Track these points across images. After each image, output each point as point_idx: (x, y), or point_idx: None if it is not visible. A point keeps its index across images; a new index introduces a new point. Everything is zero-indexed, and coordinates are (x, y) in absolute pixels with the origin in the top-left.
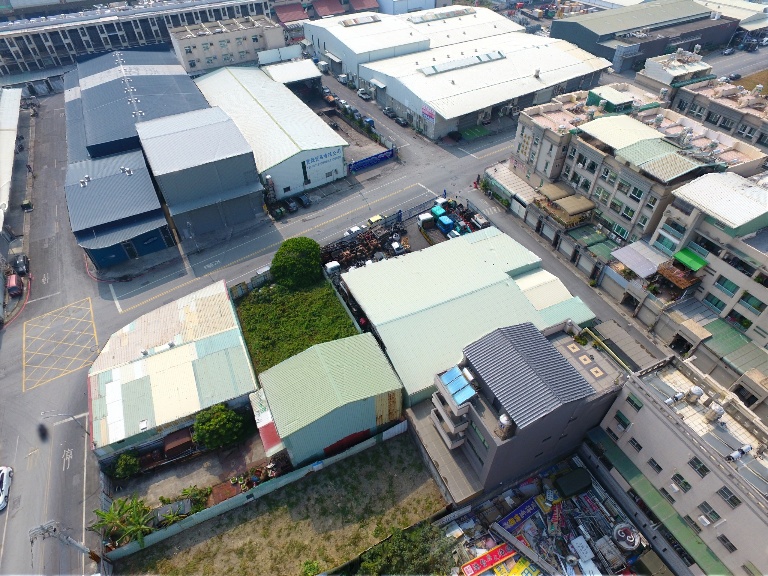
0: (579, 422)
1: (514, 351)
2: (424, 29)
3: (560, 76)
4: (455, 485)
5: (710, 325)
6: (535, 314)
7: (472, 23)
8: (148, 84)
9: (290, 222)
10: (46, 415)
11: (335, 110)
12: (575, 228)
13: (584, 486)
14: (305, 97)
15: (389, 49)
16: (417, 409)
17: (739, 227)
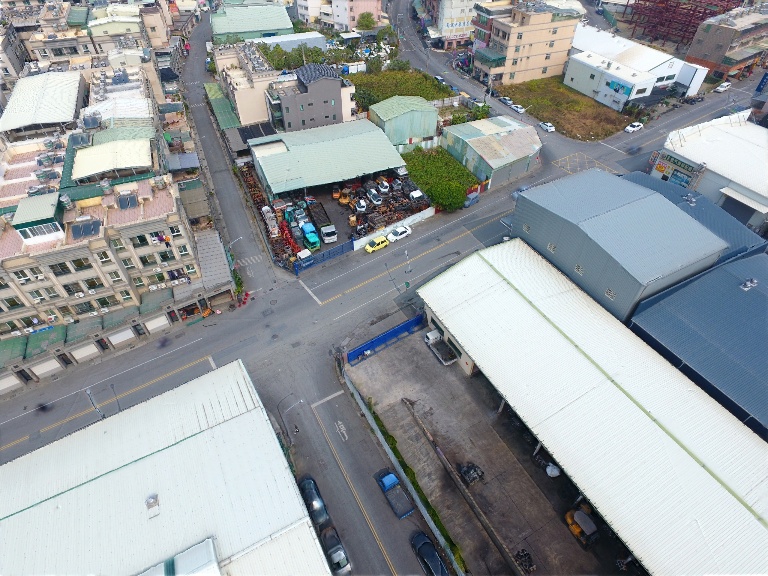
0: None
1: None
2: None
3: None
4: None
5: None
6: None
7: None
8: None
9: (473, 251)
10: (555, 145)
11: None
12: None
13: None
14: None
15: None
16: None
17: None
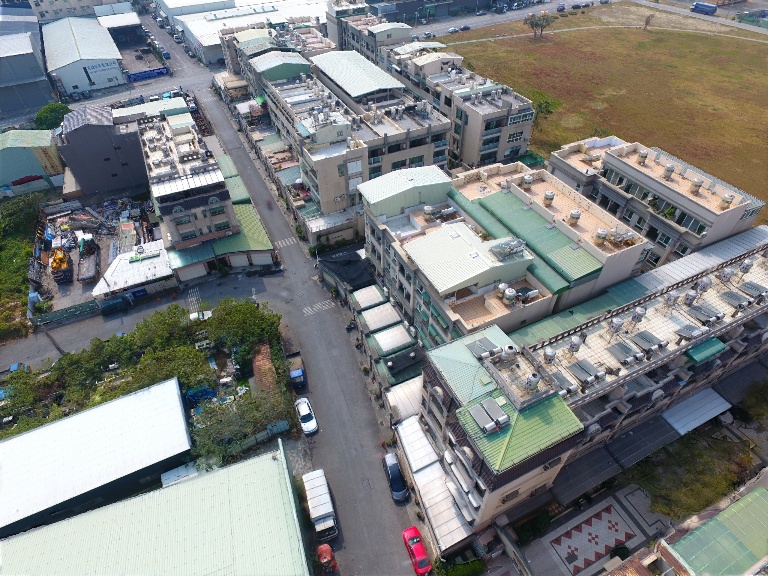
0: (129, 154)
1: None
2: None
3: None
4: (68, 189)
5: (268, 136)
6: None
7: None
8: (0, 25)
9: (71, 105)
10: None
11: (150, 49)
12: (239, 100)
13: (141, 193)
14: (134, 41)
15: (198, 6)
16: None
17: (263, 72)
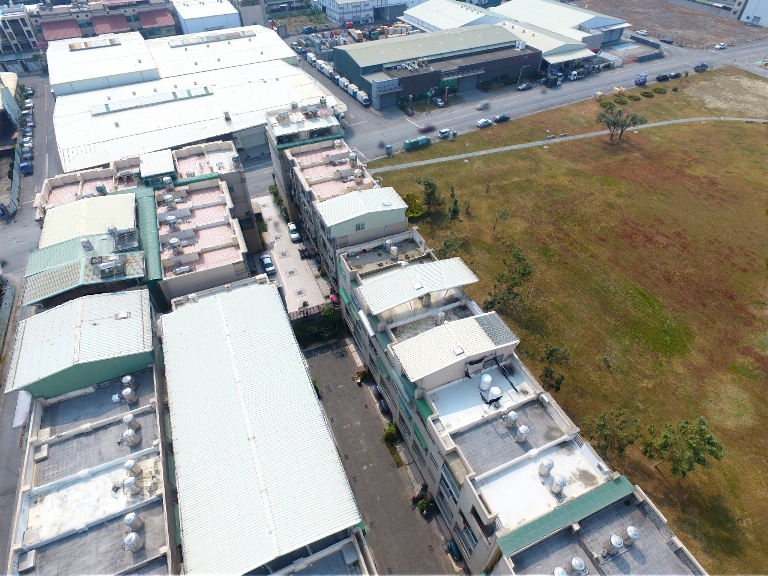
0: None
1: None
2: (177, 54)
3: (259, 118)
4: None
5: None
6: None
7: (239, 48)
8: None
9: None
10: None
11: None
12: None
13: None
14: None
15: (100, 79)
16: None
17: (22, 389)
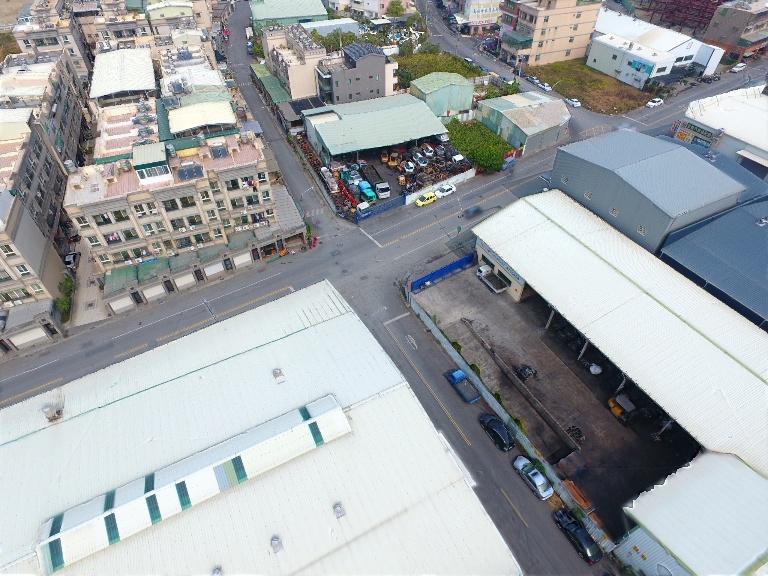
0: None
1: None
2: None
3: None
4: None
5: None
6: None
7: None
8: None
9: None
10: (581, 118)
11: None
12: None
13: None
14: None
15: None
16: None
17: None
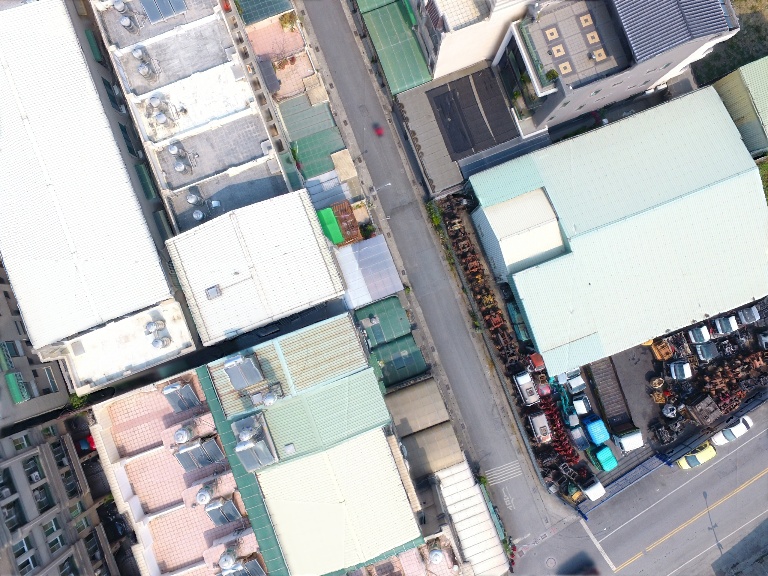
0: None
1: (684, 5)
2: None
3: None
4: None
5: (323, 171)
6: (548, 181)
7: None
8: None
9: None
10: None
11: None
12: (411, 378)
13: None
14: None
15: None
16: (688, 91)
17: None
